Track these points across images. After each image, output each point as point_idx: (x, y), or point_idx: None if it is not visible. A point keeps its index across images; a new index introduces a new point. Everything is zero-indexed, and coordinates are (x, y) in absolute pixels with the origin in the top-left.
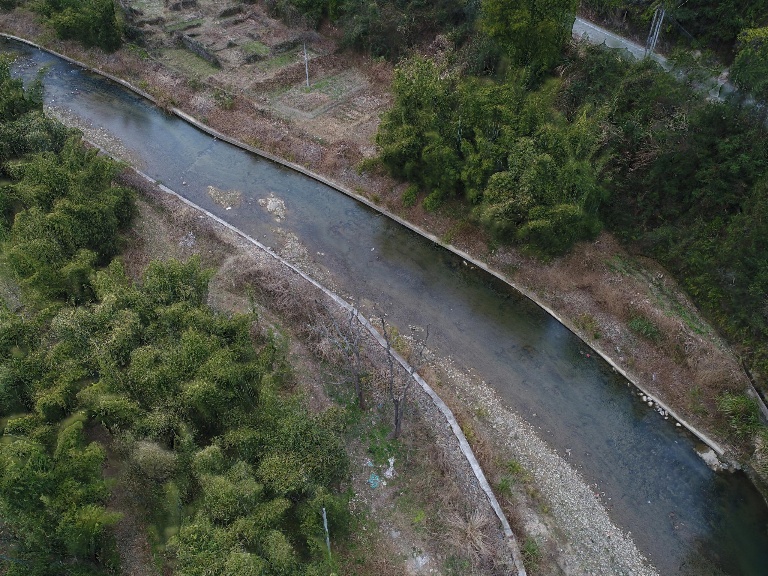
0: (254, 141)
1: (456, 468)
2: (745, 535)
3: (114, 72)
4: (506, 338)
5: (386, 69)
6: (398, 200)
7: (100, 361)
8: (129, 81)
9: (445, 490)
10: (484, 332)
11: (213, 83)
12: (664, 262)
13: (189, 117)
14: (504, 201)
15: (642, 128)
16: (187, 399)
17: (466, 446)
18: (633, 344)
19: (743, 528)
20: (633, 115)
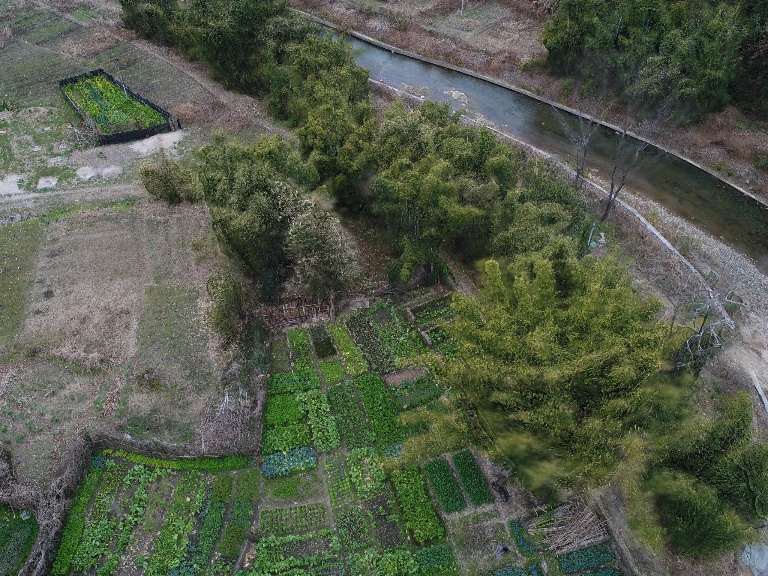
0: (429, 52)
1: (650, 237)
2: None
3: (295, 5)
4: (660, 177)
5: (524, 2)
6: (556, 91)
7: (430, 141)
8: (309, 12)
9: (647, 246)
10: (643, 173)
11: (383, 12)
12: None
13: (368, 37)
14: (657, 77)
15: (760, 27)
16: (497, 160)
17: (652, 228)
18: (759, 177)
19: None
20: (753, 17)
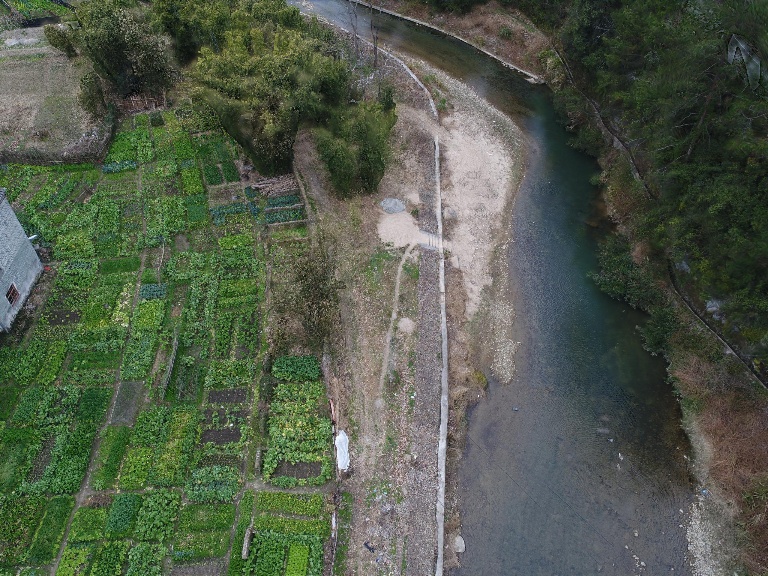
0: None
1: None
2: (540, 101)
3: None
4: (436, 49)
5: None
6: None
7: (241, 3)
8: None
9: (397, 77)
10: (424, 47)
11: None
12: (524, 12)
13: None
14: None
15: None
16: (282, 11)
17: (409, 70)
18: (501, 44)
19: (540, 99)
20: None
